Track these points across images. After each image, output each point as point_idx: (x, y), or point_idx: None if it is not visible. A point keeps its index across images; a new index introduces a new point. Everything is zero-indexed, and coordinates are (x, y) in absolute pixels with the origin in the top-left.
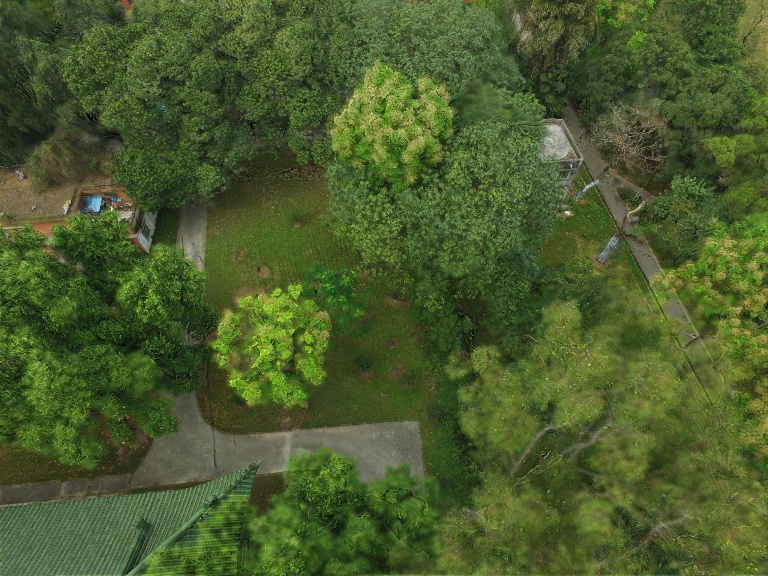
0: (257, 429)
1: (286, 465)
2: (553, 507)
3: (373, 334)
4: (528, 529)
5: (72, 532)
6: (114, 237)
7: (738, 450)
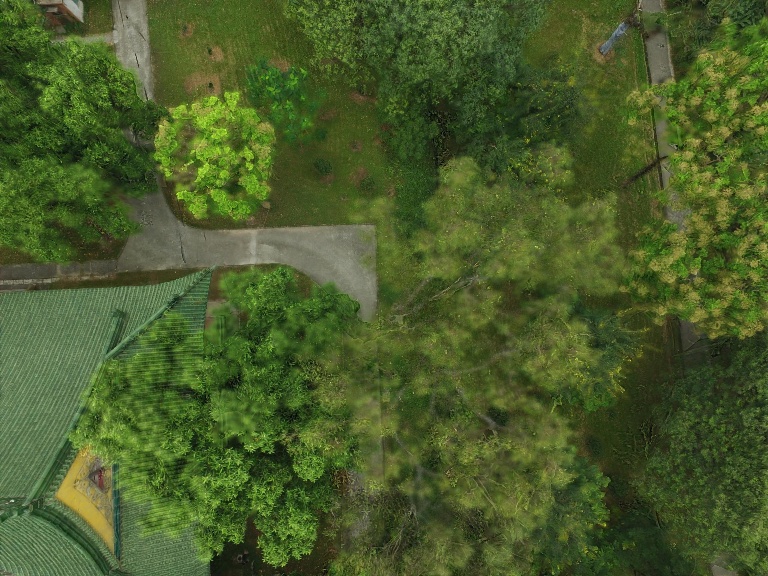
0: (224, 226)
1: (253, 259)
2: (490, 300)
3: (335, 135)
4: (465, 316)
5: (63, 315)
6: (19, 22)
7: (649, 273)
